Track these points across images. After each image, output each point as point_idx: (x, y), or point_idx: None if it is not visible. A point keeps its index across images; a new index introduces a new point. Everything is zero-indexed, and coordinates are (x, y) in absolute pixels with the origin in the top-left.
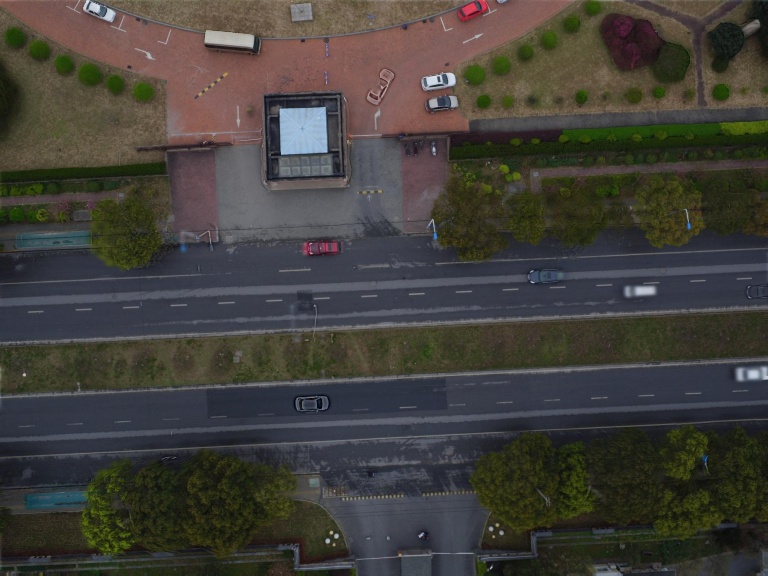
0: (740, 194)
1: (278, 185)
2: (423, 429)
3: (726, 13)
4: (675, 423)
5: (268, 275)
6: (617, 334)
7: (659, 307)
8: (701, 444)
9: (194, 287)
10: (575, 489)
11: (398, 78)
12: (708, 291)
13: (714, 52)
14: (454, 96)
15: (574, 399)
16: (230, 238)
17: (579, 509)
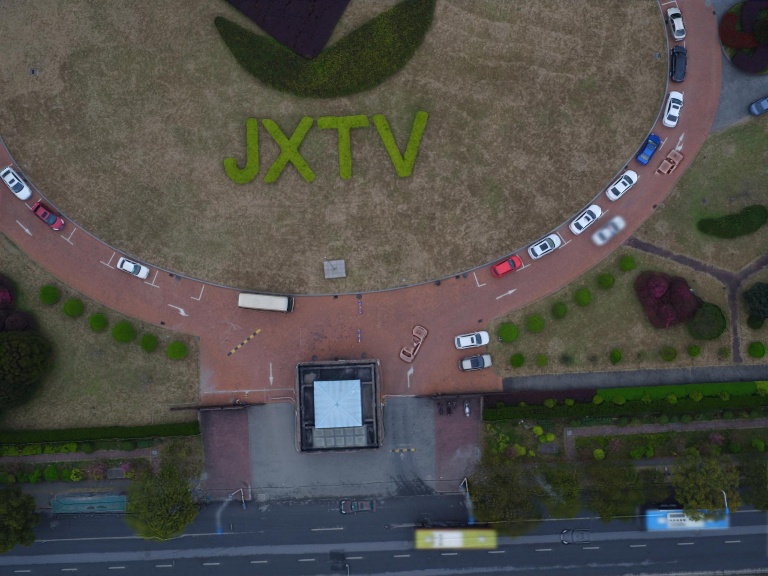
0: None
1: (312, 453)
2: None
3: (762, 267)
4: None
5: (300, 534)
6: None
7: (693, 568)
8: None
9: (226, 546)
10: None
11: (431, 335)
12: (743, 552)
13: (750, 311)
14: (487, 355)
15: None
16: (262, 496)
17: None
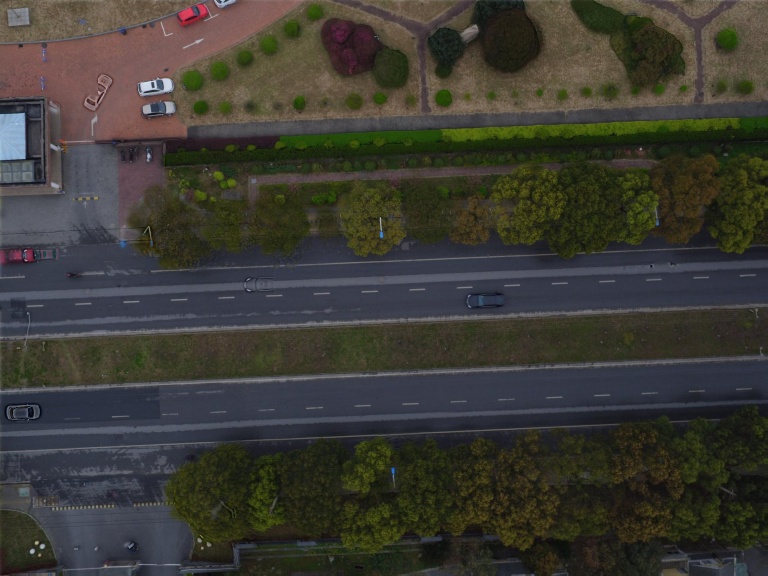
0: (462, 202)
1: None
2: (135, 438)
3: (452, 18)
4: (378, 434)
5: None
6: (333, 343)
7: (377, 316)
8: (383, 456)
9: None
10: (259, 501)
11: (116, 84)
12: (427, 300)
13: (435, 57)
14: (171, 102)
15: (289, 409)
16: None
17: (268, 521)
